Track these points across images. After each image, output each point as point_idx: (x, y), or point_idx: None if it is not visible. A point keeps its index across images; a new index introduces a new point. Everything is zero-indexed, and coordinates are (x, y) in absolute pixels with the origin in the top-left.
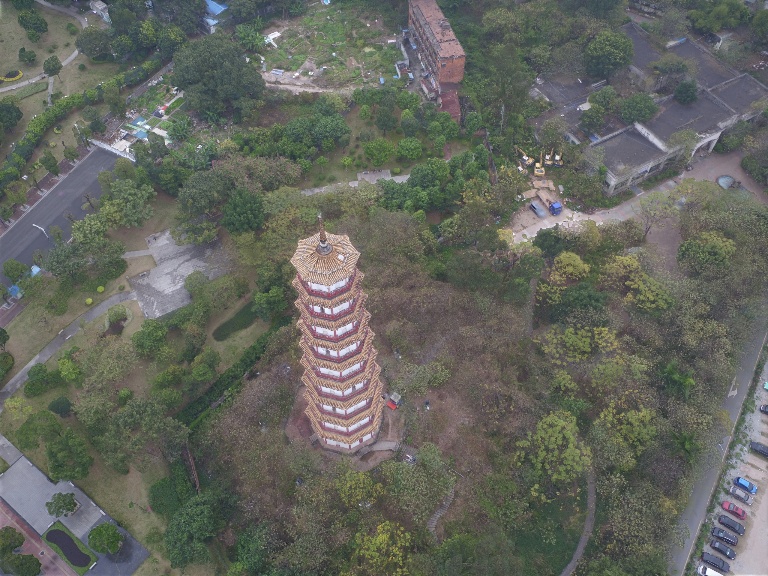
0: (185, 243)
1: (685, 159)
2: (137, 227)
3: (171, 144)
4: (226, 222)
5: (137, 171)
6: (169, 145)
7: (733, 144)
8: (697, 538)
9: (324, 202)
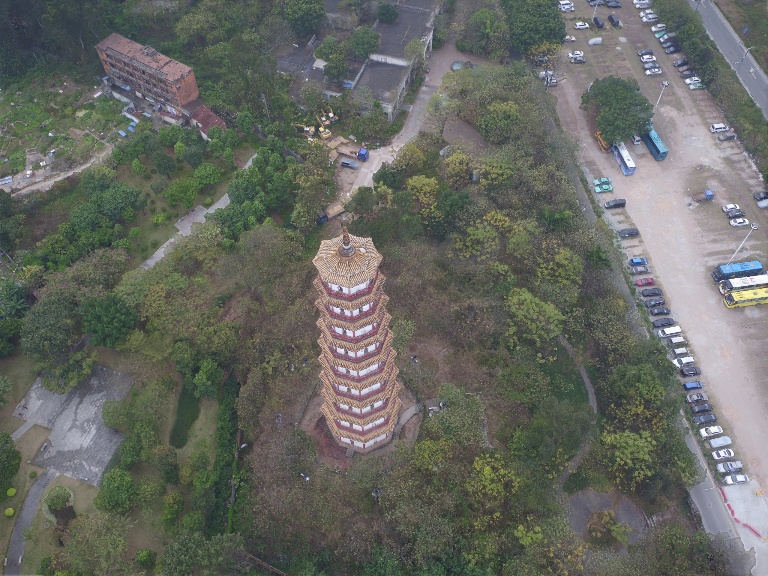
0: (74, 385)
1: (421, 65)
2: (0, 407)
3: None
4: (98, 339)
5: None
6: None
7: (445, 36)
8: None
9: (175, 264)
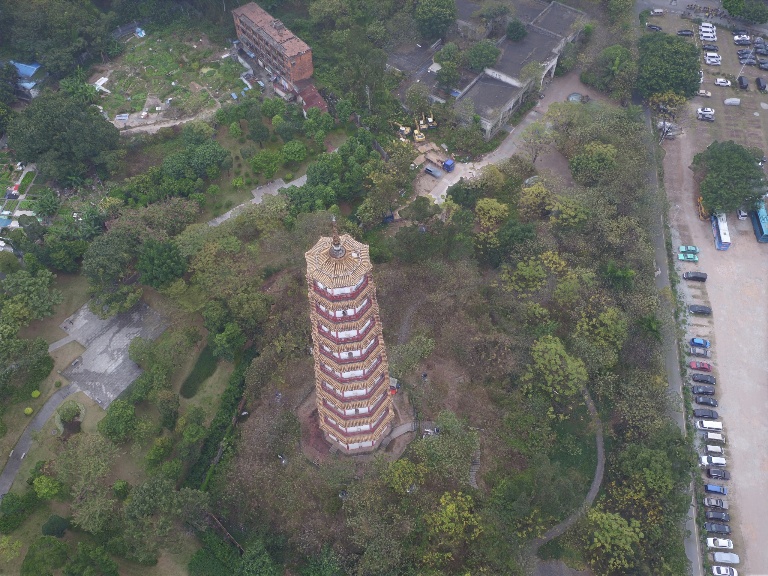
0: (113, 314)
1: (537, 89)
2: None
3: (42, 222)
4: (147, 279)
5: (26, 259)
6: (40, 224)
7: (570, 65)
8: (684, 401)
9: (236, 227)
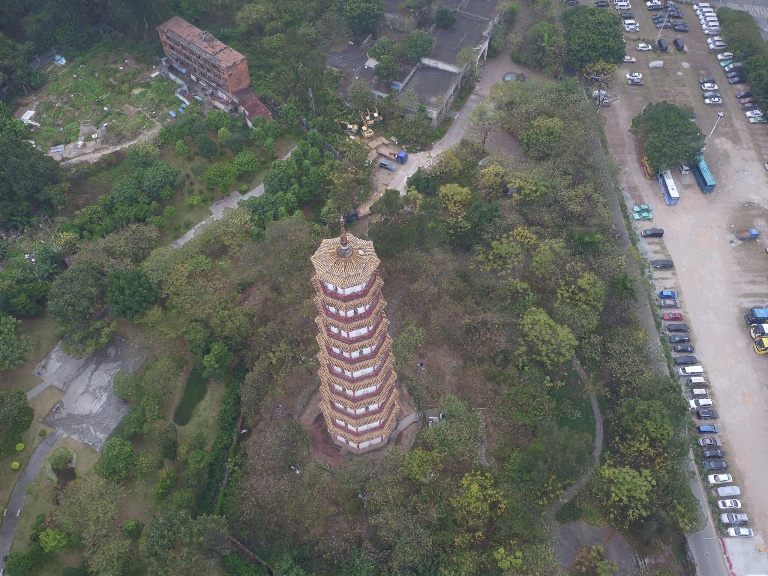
0: (90, 352)
1: (473, 73)
2: None
3: None
4: (119, 311)
5: None
6: None
7: (501, 46)
8: None
9: (202, 246)
